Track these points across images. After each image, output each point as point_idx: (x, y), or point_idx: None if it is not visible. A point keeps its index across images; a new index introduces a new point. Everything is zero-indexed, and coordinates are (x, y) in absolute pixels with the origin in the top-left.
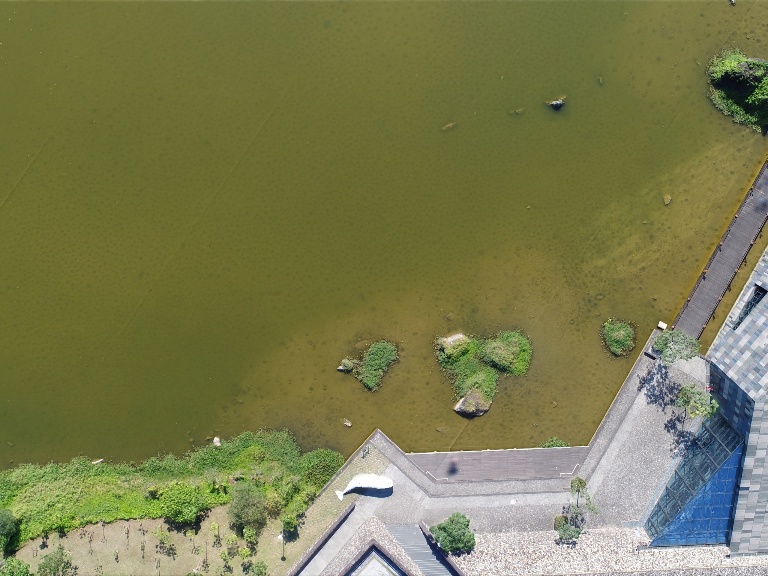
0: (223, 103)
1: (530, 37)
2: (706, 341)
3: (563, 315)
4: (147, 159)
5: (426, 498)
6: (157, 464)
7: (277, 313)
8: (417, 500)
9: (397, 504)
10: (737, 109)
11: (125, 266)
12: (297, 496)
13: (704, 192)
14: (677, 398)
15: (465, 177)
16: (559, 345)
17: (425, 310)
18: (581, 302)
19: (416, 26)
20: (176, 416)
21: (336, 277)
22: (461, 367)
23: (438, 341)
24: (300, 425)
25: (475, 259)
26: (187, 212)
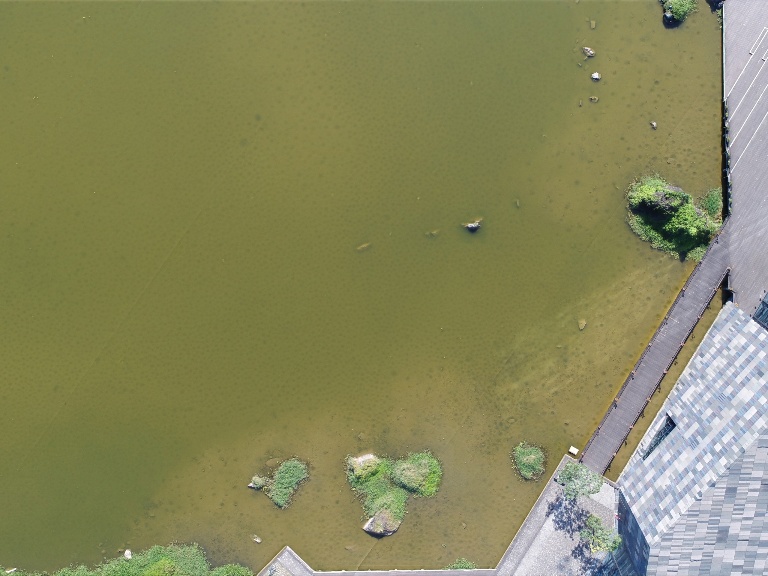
0: (139, 219)
1: (447, 158)
2: (617, 467)
3: (474, 438)
4: (63, 273)
5: None
6: (69, 575)
7: (190, 429)
8: None
9: None
10: (655, 235)
11: (40, 379)
12: None
13: (619, 317)
14: (584, 526)
15: (379, 297)
16: (469, 467)
17: (336, 429)
18: (493, 425)
19: (333, 145)
20: (89, 527)
21: (249, 394)
22: (371, 487)
23: (348, 461)
24: (210, 540)
25: (387, 380)
26: (102, 327)
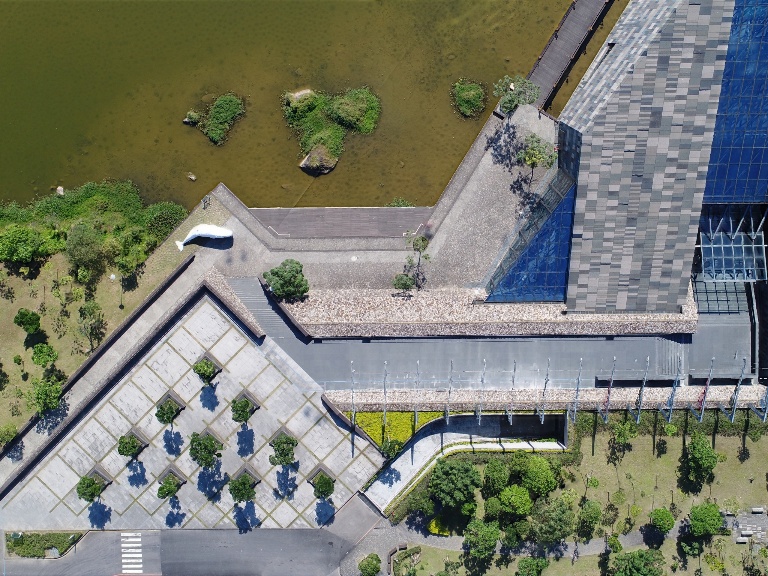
0: None
1: None
2: (558, 105)
3: (413, 74)
4: None
5: (266, 252)
6: (0, 211)
7: (124, 63)
8: (257, 253)
9: (237, 257)
10: None
11: None
12: (138, 246)
13: None
14: None
15: None
16: (408, 104)
17: (273, 65)
18: (432, 61)
19: None
20: (21, 165)
21: (184, 29)
22: (308, 123)
23: (285, 96)
24: (144, 177)
25: (326, 14)
26: None
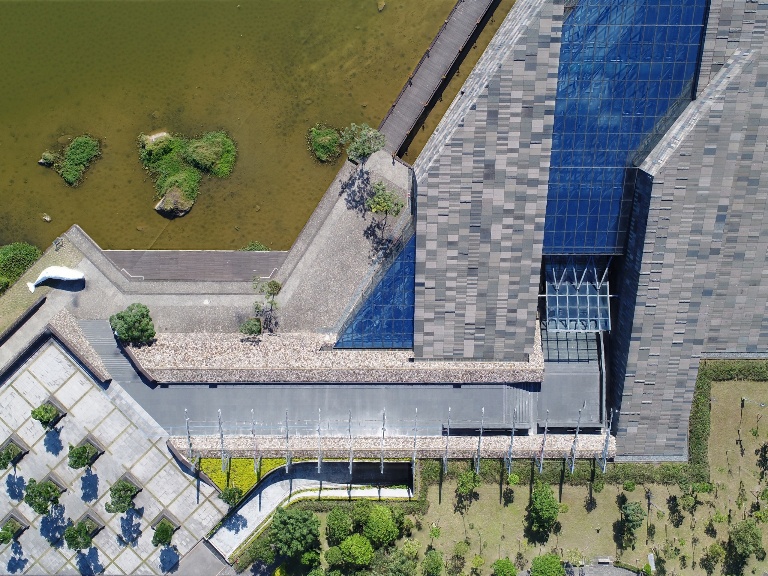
0: None
1: None
2: (414, 151)
3: (270, 118)
4: None
5: (118, 294)
6: None
7: None
8: (109, 296)
9: (89, 299)
10: None
11: None
12: None
13: None
14: None
15: None
16: (264, 148)
17: (130, 107)
18: (289, 106)
19: None
20: None
21: (42, 70)
22: (163, 166)
23: (141, 138)
24: None
25: (183, 58)
26: None
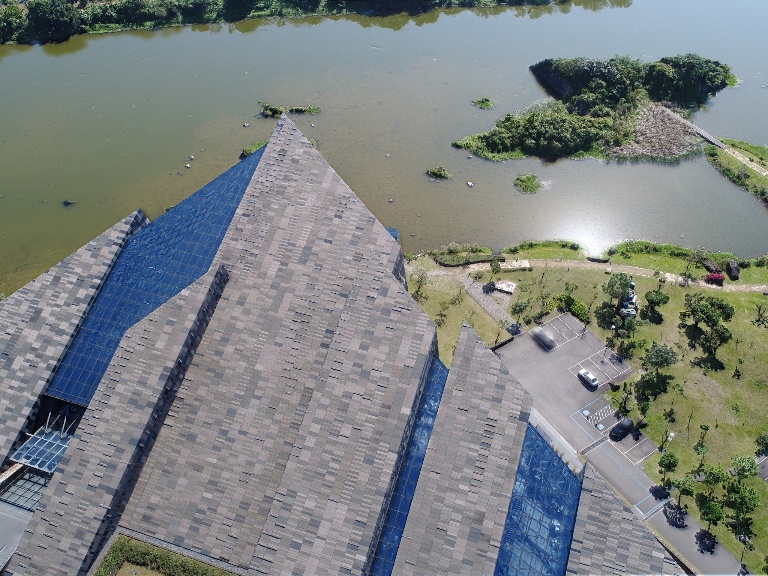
0: None
1: (82, 176)
2: None
3: None
4: None
5: None
6: None
7: None
8: None
9: None
10: None
11: None
12: None
13: None
14: None
15: None
16: None
17: None
18: None
19: (29, 158)
20: None
21: None
22: None
23: None
24: None
25: None
26: None
